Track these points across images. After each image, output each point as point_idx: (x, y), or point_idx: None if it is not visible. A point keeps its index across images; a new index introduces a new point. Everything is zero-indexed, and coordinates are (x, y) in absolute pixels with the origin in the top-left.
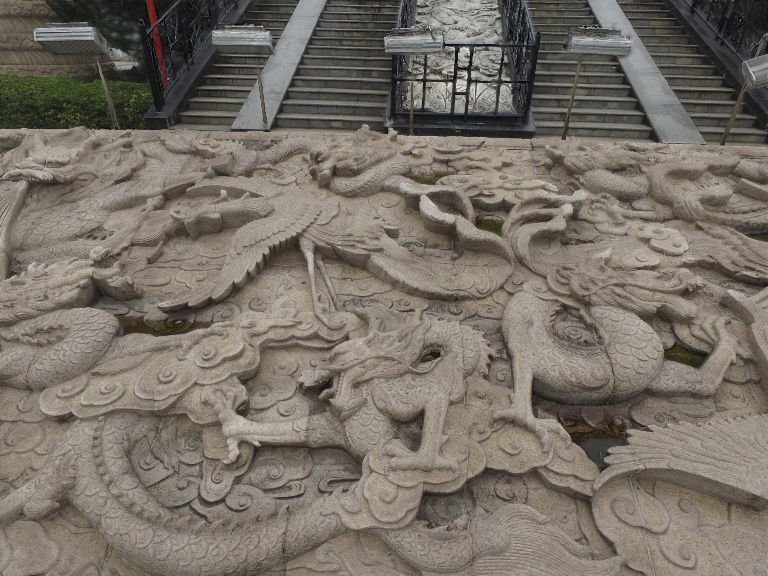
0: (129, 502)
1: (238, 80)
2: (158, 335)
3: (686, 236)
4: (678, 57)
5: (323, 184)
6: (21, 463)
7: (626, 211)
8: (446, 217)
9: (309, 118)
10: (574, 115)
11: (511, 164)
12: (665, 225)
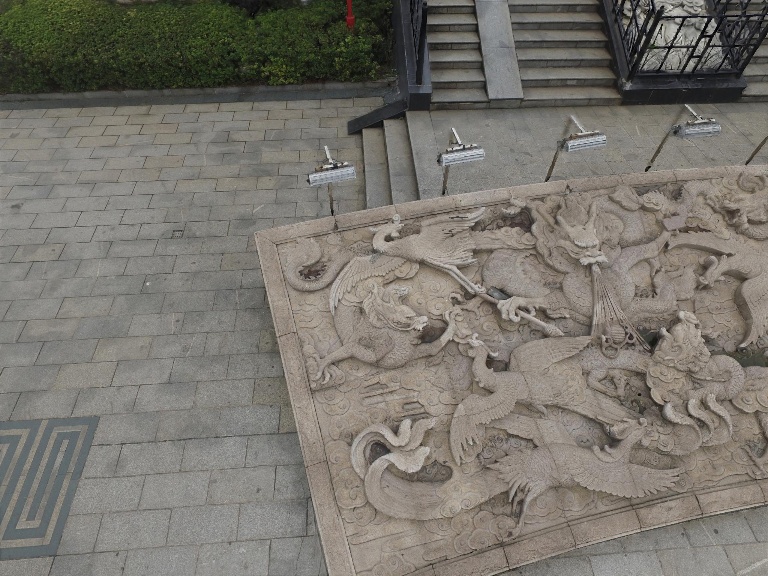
0: None
1: (455, 26)
2: (744, 361)
3: None
4: None
5: None
6: (749, 433)
7: None
8: None
9: (549, 78)
10: (765, 58)
11: None
12: None
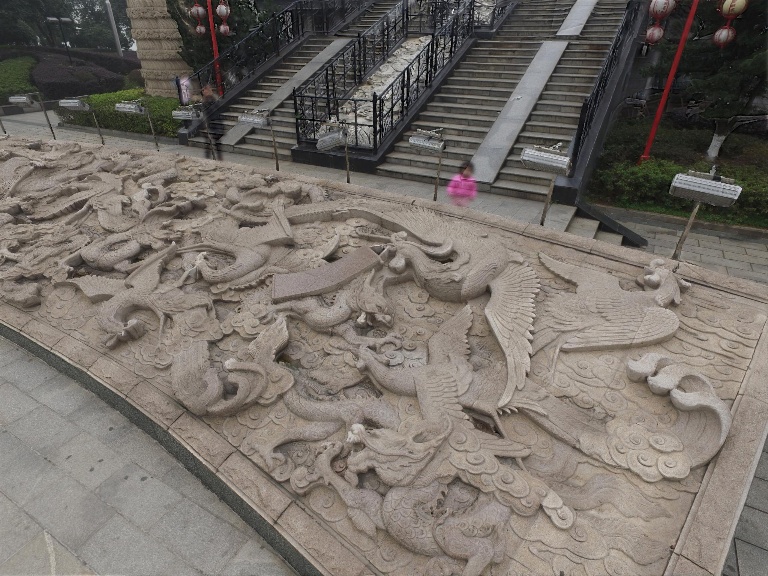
0: None
1: (246, 109)
2: None
3: (209, 221)
4: (562, 106)
5: (135, 180)
6: None
7: (222, 209)
8: None
9: (261, 139)
10: None
11: (224, 180)
12: (221, 217)
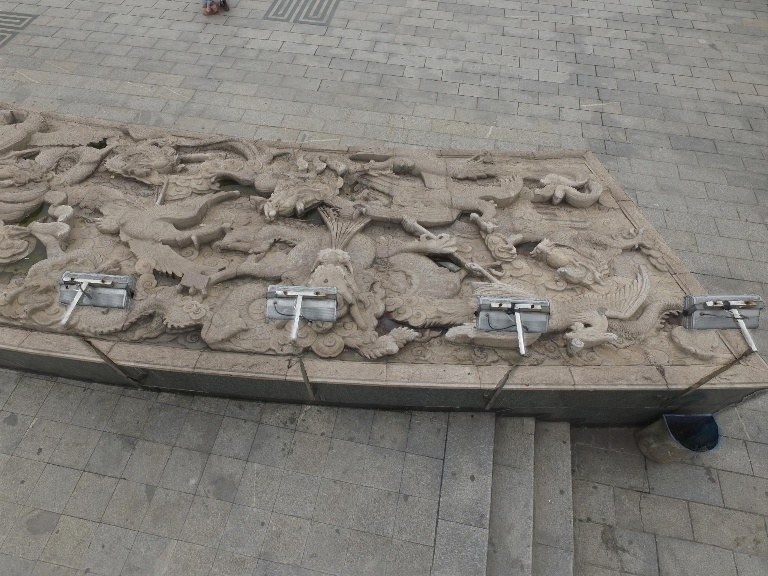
0: (239, 139)
1: None
2: (242, 190)
3: None
4: None
5: None
6: None
7: None
8: (62, 207)
9: None
10: None
11: None
12: None
